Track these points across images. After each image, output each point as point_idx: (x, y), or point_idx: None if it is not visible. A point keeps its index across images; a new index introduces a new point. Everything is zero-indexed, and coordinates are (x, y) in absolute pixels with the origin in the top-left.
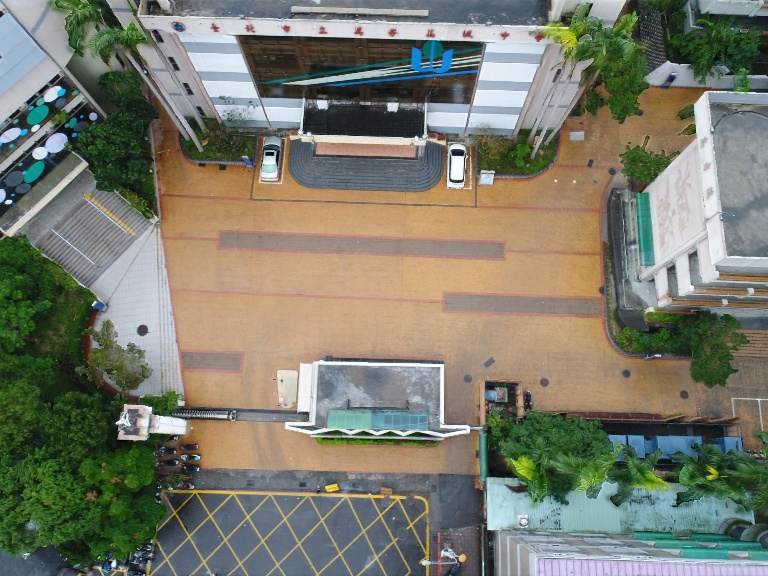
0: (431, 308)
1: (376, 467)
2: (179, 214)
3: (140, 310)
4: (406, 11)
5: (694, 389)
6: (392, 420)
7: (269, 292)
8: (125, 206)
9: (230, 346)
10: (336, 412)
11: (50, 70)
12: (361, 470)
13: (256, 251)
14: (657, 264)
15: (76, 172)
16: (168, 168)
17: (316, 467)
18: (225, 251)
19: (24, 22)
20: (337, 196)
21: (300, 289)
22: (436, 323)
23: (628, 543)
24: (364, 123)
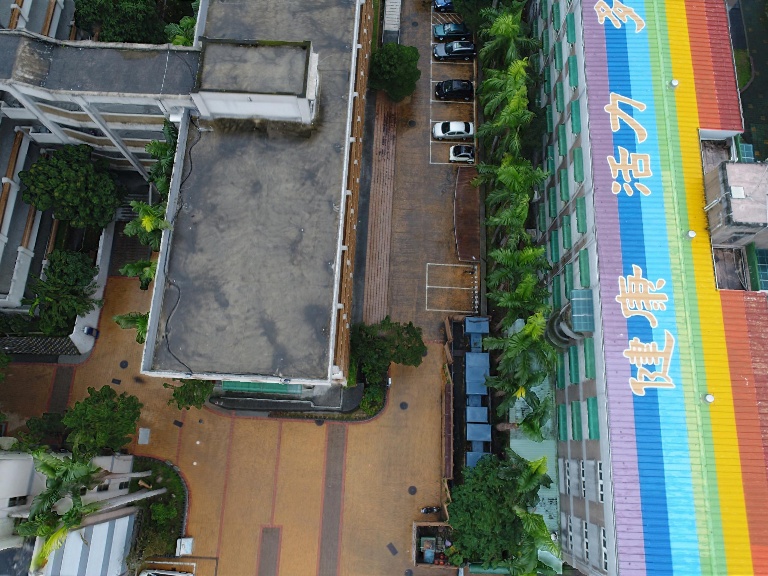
0: None
1: None
2: None
3: None
4: None
5: None
6: None
7: None
8: None
9: None
10: None
11: None
12: None
13: None
14: None
15: None
16: None
17: None
18: None
19: None
20: None
21: None
22: None
23: (575, 456)
24: None
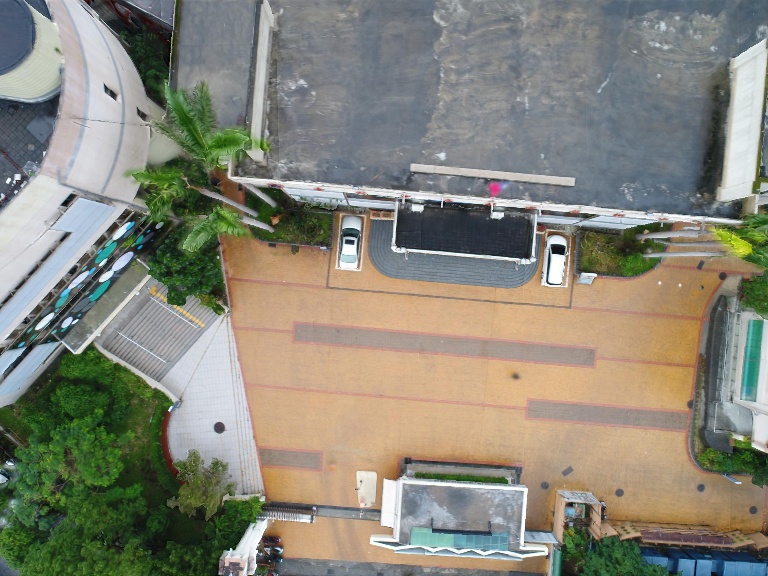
0: (514, 415)
1: (450, 563)
2: (250, 302)
3: (215, 407)
4: (549, 178)
5: (764, 505)
6: (474, 539)
7: (348, 391)
8: (193, 298)
9: (309, 445)
10: (419, 529)
11: (118, 210)
12: (436, 565)
13: (334, 346)
14: (759, 405)
15: (143, 282)
16: (235, 247)
17: (393, 561)
18: (301, 345)
19: (94, 188)
20: (421, 289)
21: (380, 389)
22: (518, 430)
23: None
24: (463, 231)
